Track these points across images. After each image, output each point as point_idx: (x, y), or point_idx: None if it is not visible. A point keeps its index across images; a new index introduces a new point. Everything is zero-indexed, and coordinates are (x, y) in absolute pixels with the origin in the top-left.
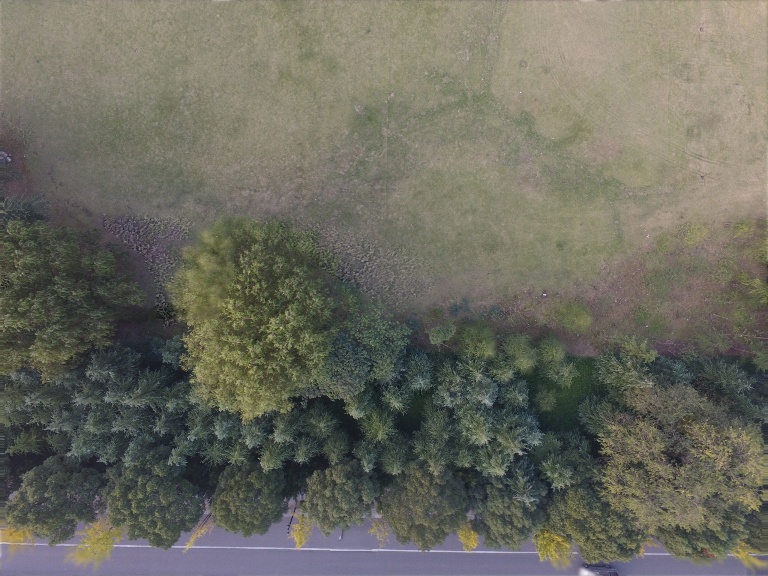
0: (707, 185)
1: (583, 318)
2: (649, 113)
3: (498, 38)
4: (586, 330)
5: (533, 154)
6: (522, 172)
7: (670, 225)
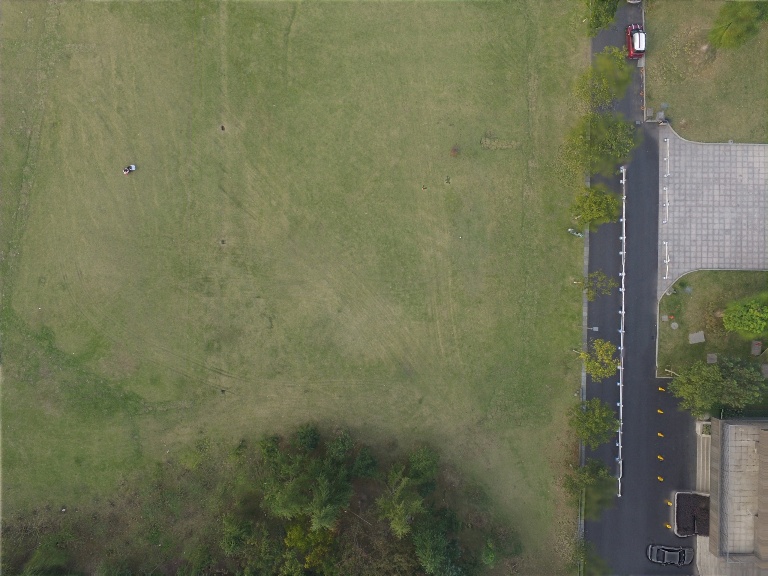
0: (227, 400)
1: (99, 535)
2: (168, 328)
3: (19, 254)
4: (101, 548)
5: (52, 370)
6: (42, 388)
7: (189, 440)
